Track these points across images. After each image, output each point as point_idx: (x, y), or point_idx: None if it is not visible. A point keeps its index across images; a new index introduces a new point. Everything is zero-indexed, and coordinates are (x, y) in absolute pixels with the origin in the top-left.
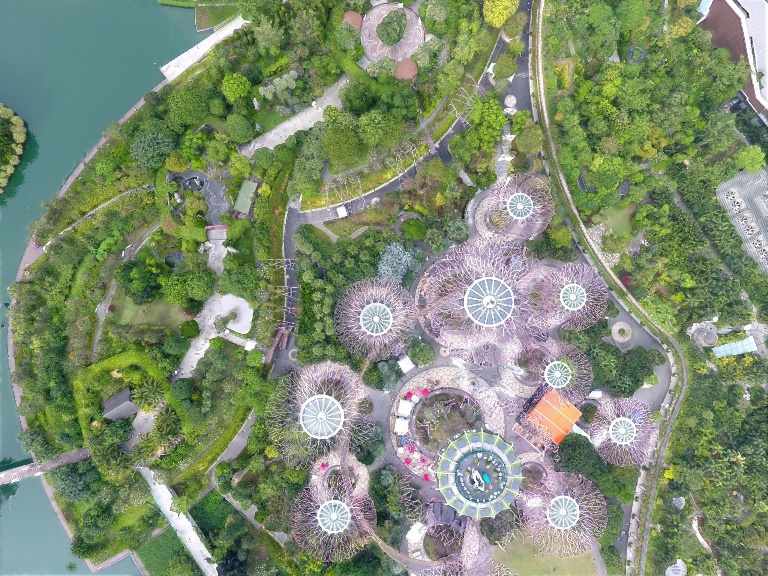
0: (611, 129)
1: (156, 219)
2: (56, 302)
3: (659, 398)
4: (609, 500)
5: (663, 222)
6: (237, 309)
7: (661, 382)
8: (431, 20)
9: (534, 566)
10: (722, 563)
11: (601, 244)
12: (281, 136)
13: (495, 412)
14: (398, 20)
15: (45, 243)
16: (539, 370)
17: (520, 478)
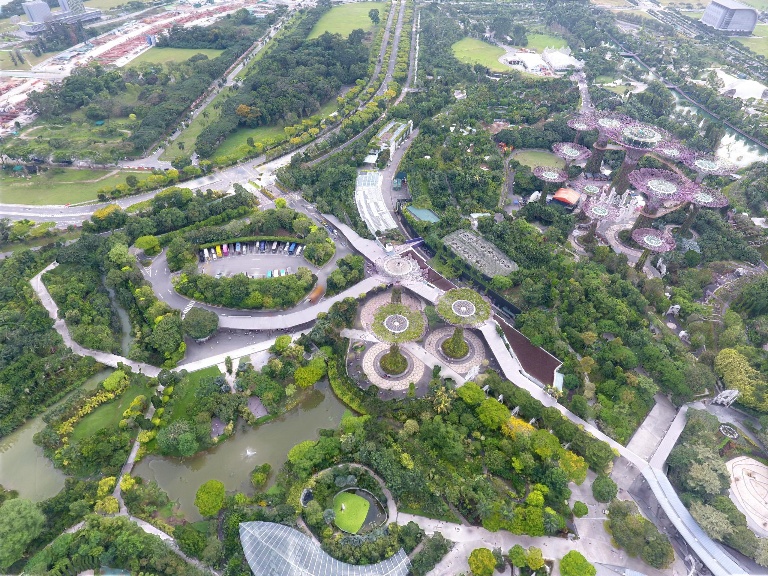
0: None
1: None
2: None
3: None
4: None
5: None
6: (766, 225)
7: None
8: None
9: None
10: None
11: None
12: None
13: None
14: None
15: None
16: None
17: None
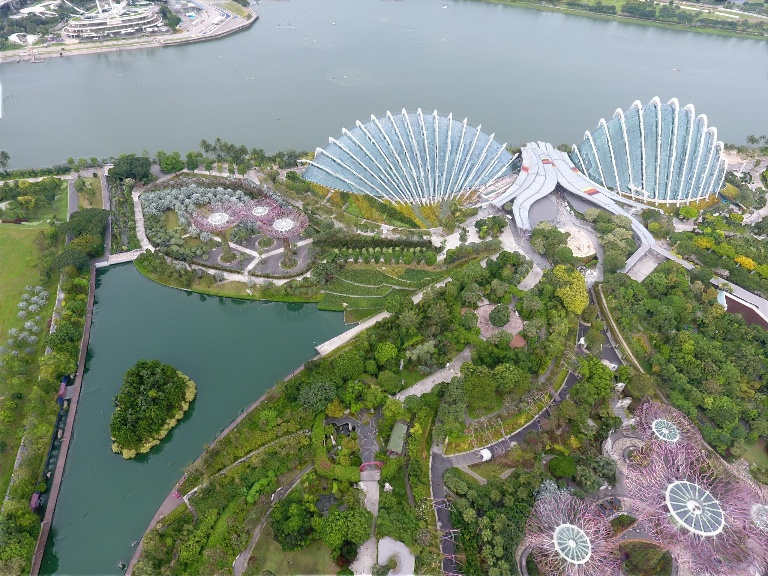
0: (705, 376)
1: (309, 461)
2: (191, 554)
3: None
4: None
5: None
6: (396, 556)
7: None
8: (528, 310)
9: None
10: None
11: (753, 479)
12: (422, 390)
13: None
14: (505, 310)
15: (187, 492)
16: None
17: None
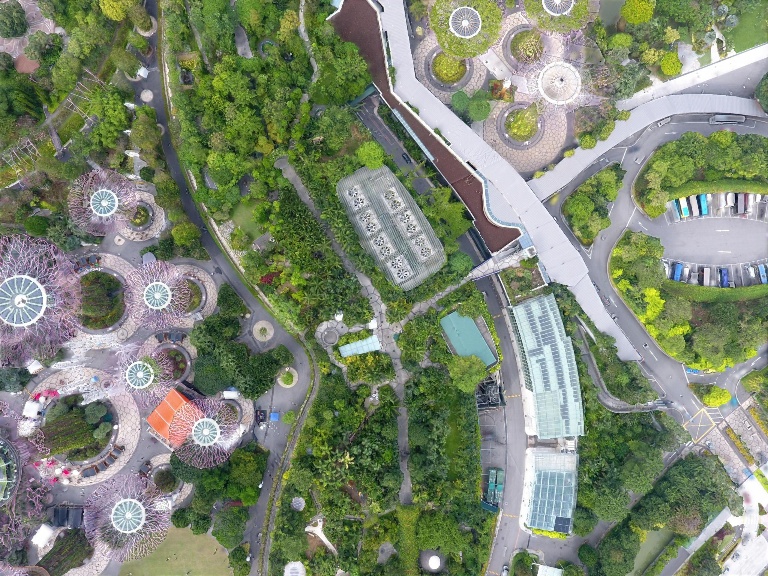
0: None
1: None
2: None
3: (301, 398)
4: (233, 502)
5: (271, 219)
6: None
7: (303, 382)
8: None
9: (168, 570)
10: (340, 565)
11: (231, 242)
12: None
13: (130, 413)
14: (8, 12)
15: None
16: (122, 370)
17: (4, 482)
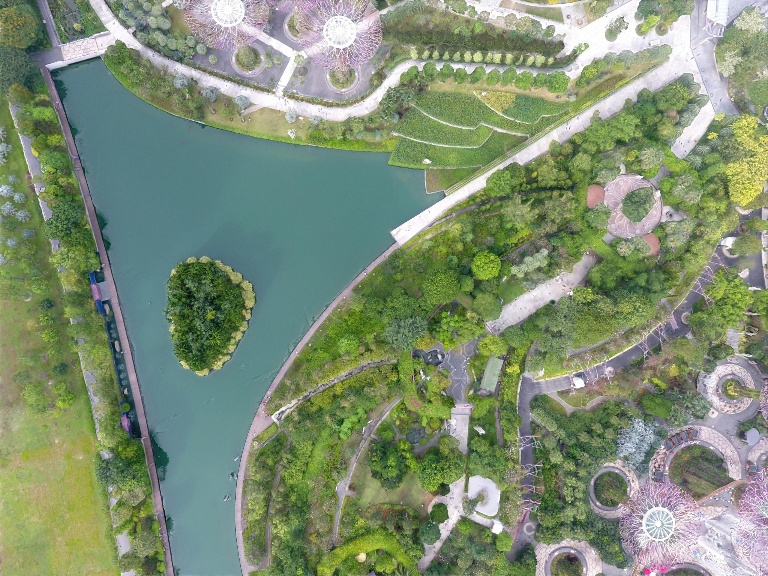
0: None
1: None
2: (295, 480)
3: None
4: None
5: None
6: (484, 490)
7: None
8: (679, 199)
9: None
10: None
11: None
12: (521, 308)
13: None
14: (648, 200)
15: (274, 412)
16: None
17: None
